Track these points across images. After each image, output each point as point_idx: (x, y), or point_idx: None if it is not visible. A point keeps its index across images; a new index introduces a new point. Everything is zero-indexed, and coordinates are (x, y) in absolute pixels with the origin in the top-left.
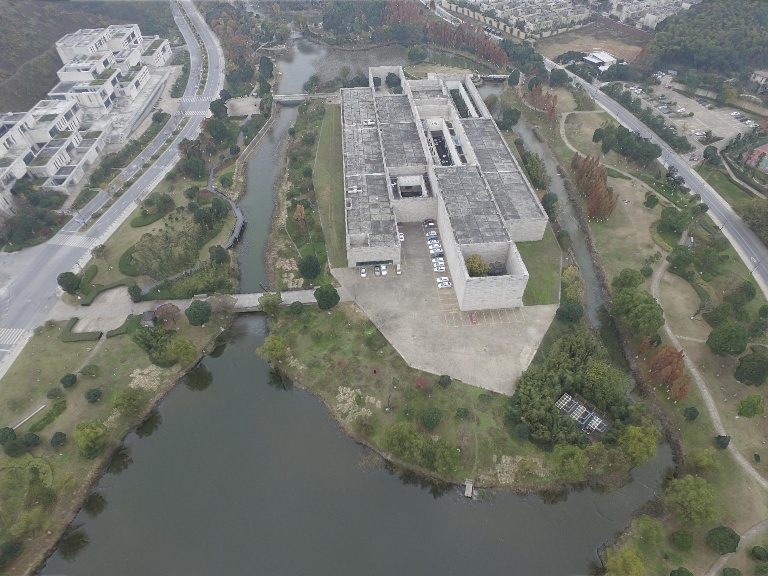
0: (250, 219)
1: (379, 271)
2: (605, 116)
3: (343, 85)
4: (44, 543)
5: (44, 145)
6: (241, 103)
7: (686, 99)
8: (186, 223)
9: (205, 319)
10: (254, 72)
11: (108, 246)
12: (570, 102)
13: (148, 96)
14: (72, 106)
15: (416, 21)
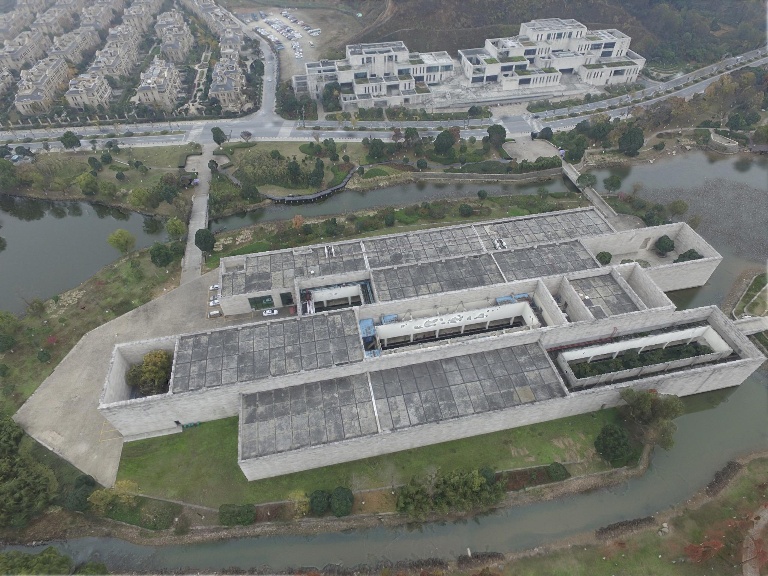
0: None
1: (214, 298)
2: None
3: None
4: (43, 194)
5: (387, 76)
6: (541, 149)
7: None
8: (286, 164)
9: (166, 200)
10: (615, 137)
11: (278, 144)
12: None
13: (514, 95)
14: (445, 65)
15: None
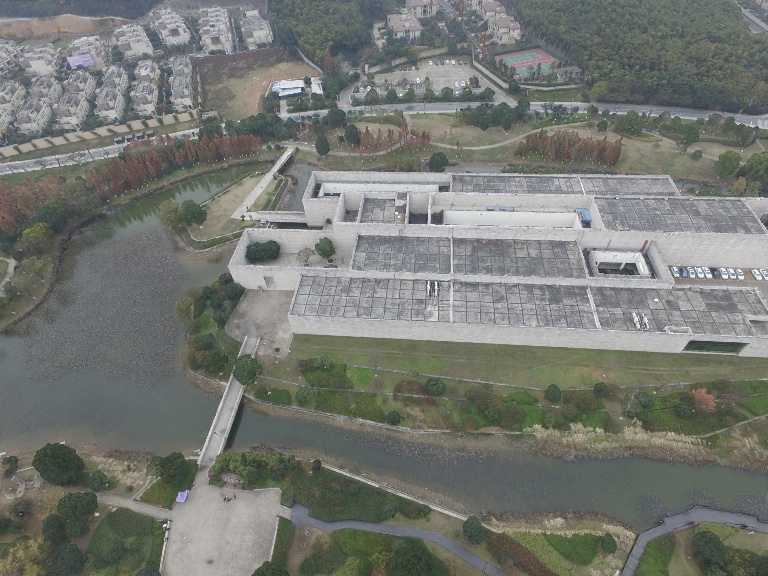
0: (673, 503)
1: None
2: (419, 116)
3: (218, 325)
4: None
5: None
6: (199, 539)
7: (395, 74)
8: None
9: None
10: None
11: None
12: (383, 127)
13: None
14: None
15: (42, 193)
